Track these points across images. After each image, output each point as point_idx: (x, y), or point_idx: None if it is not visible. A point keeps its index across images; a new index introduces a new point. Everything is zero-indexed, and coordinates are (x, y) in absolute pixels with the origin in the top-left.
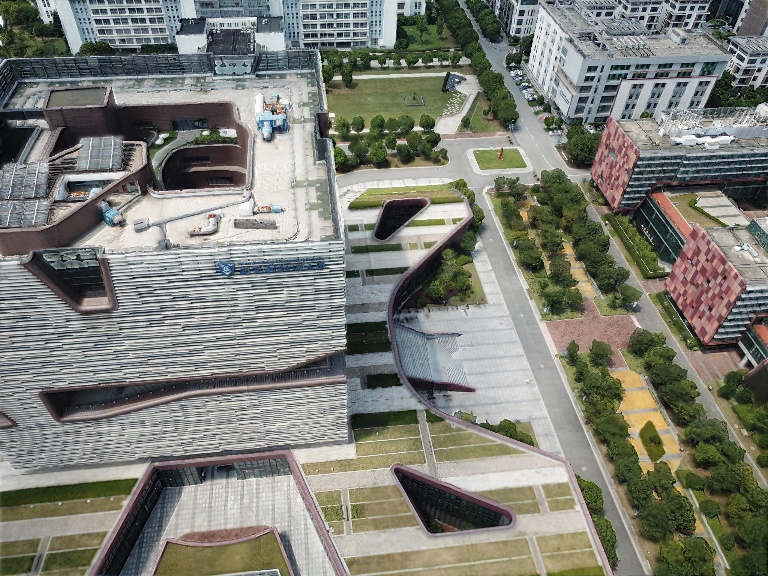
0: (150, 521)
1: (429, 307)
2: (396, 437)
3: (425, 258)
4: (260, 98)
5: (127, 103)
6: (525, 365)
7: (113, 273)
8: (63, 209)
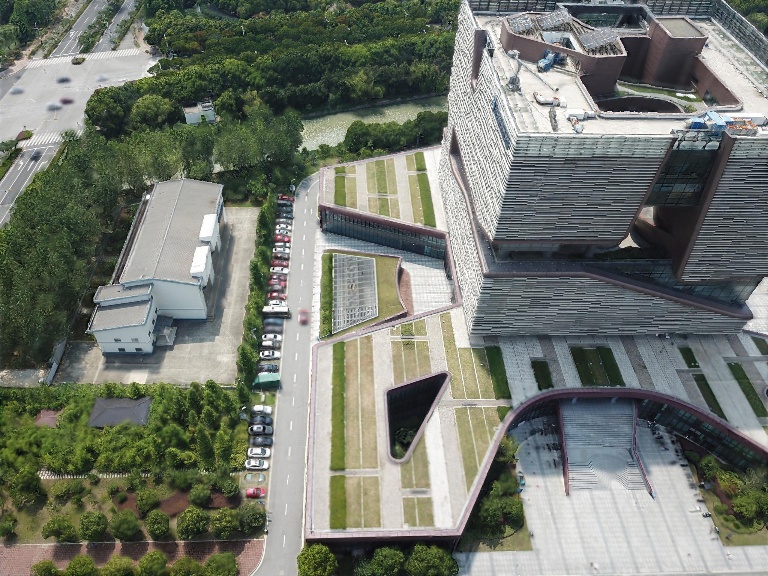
0: (419, 256)
1: (690, 467)
2: (479, 379)
3: (752, 440)
4: (756, 115)
5: (709, 61)
6: (621, 569)
7: (481, 64)
8: (535, 37)
